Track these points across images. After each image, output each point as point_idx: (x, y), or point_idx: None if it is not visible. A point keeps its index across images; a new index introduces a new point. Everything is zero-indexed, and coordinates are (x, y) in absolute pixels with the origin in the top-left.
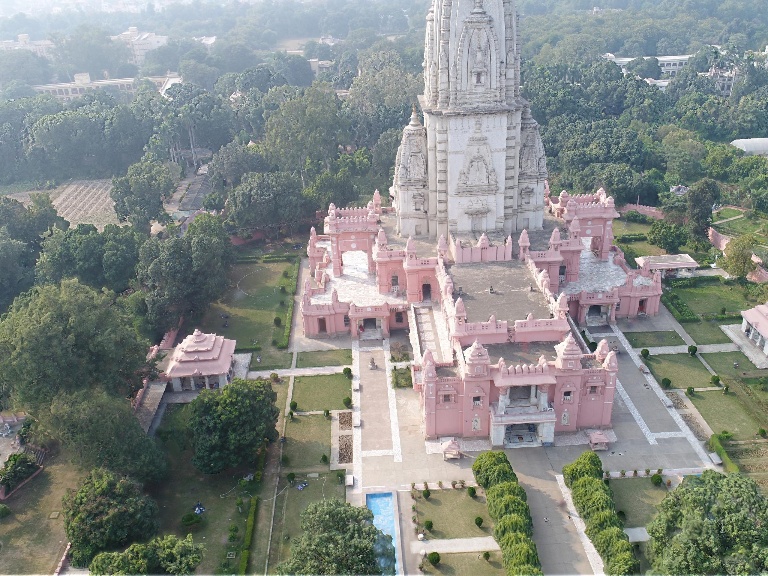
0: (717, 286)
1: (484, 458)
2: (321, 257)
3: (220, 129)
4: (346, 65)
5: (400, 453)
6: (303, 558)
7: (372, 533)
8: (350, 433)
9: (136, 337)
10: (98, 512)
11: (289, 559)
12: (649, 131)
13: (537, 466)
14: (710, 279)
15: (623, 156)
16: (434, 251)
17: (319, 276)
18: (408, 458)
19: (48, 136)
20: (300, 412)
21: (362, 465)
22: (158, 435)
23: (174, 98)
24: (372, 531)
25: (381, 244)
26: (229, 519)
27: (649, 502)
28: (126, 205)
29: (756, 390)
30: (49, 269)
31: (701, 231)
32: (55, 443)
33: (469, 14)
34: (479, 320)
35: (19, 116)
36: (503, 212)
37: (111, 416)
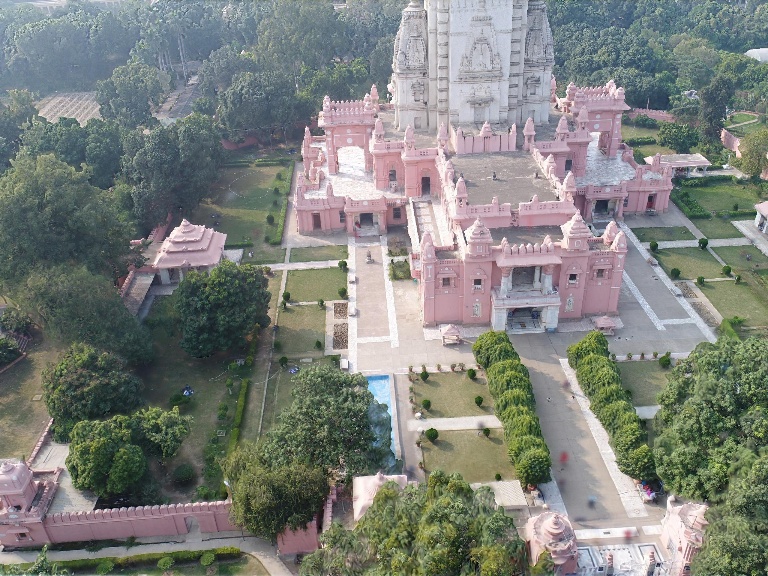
0: (729, 185)
1: (485, 338)
2: (316, 157)
3: (211, 38)
4: None
5: (397, 339)
6: (294, 423)
7: (366, 396)
8: (345, 321)
9: None
10: (79, 384)
11: (279, 426)
12: (660, 41)
13: (540, 350)
14: (722, 179)
15: (633, 62)
16: (434, 143)
17: (313, 174)
18: (405, 344)
19: (30, 45)
20: (293, 303)
21: (357, 351)
22: (145, 324)
23: None
24: (366, 394)
25: (378, 135)
26: (219, 401)
27: (656, 383)
28: (112, 108)
29: None
30: None
31: (713, 132)
32: (38, 332)
33: None
34: (481, 204)
35: (0, 27)
36: (507, 101)
37: (92, 290)
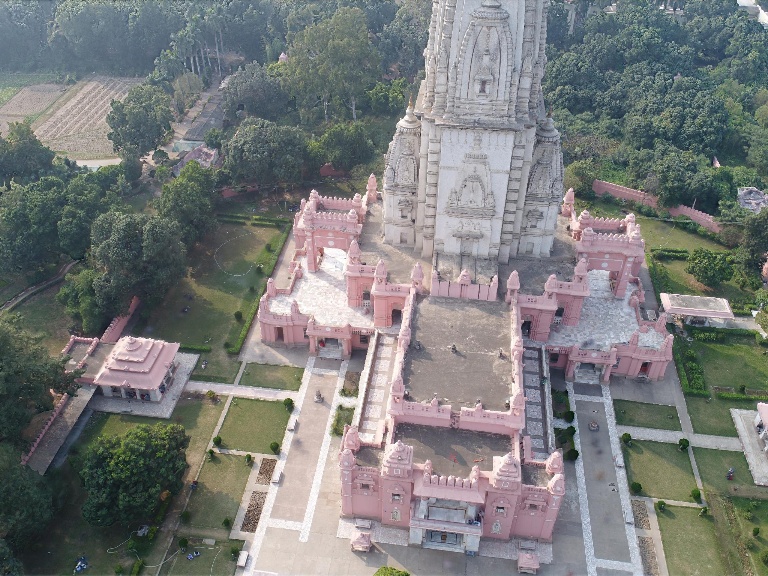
0: (749, 346)
1: None
2: None
3: (252, 34)
4: None
5: (308, 530)
6: None
7: None
8: (265, 490)
9: (82, 319)
10: None
11: None
12: (745, 93)
13: None
14: (744, 334)
15: (697, 134)
16: None
17: (293, 267)
18: (314, 539)
19: (70, 24)
20: (223, 449)
21: (263, 538)
22: (71, 453)
23: None
24: None
25: (352, 257)
26: None
27: None
28: (120, 135)
29: (741, 517)
30: (5, 227)
31: (754, 264)
32: None
33: (479, 6)
34: (424, 394)
35: None
36: (499, 238)
37: None
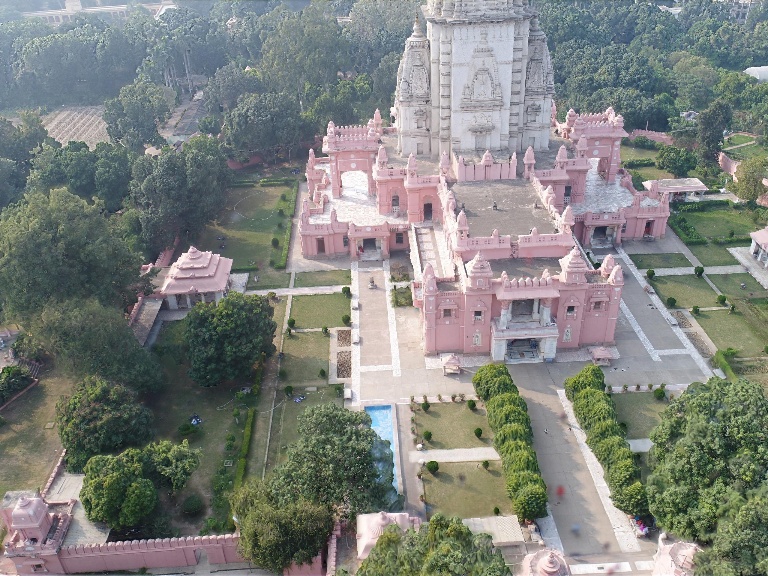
0: (726, 210)
1: (485, 370)
2: (320, 179)
3: (216, 54)
4: None
5: (399, 368)
6: (300, 460)
7: (370, 435)
8: (349, 349)
9: None
10: (92, 417)
11: (286, 462)
12: (660, 58)
13: (538, 381)
14: (719, 203)
15: (632, 82)
16: (436, 170)
17: (318, 197)
18: (407, 373)
19: (38, 59)
20: (298, 329)
21: (361, 379)
22: (154, 350)
23: (168, 24)
24: (370, 433)
25: (381, 162)
26: (226, 430)
27: (651, 415)
28: (119, 127)
29: (763, 310)
30: (40, 187)
31: (711, 156)
32: (50, 358)
33: None
34: (482, 235)
35: (8, 40)
36: (508, 129)
37: (104, 324)
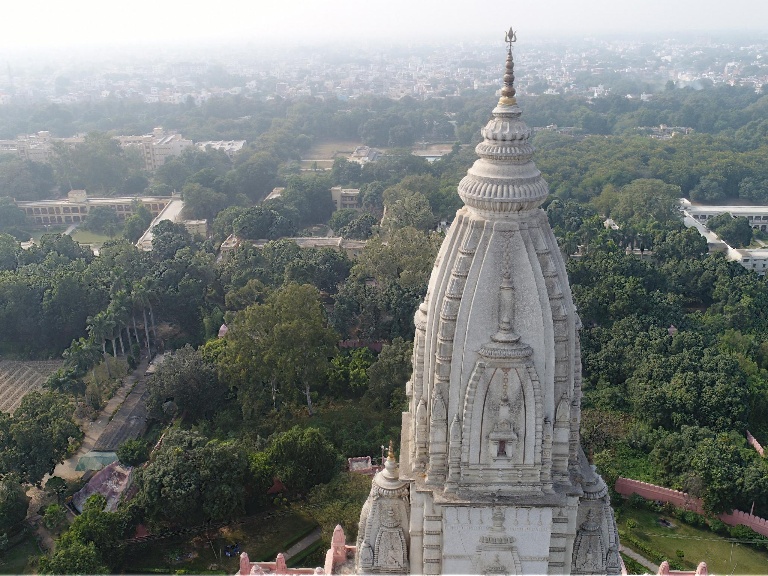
0: None
1: None
2: None
3: (188, 306)
4: (371, 199)
5: None
6: None
7: None
8: None
9: None
10: None
11: None
12: (749, 343)
13: None
14: None
15: (720, 405)
16: None
17: None
18: None
19: None
20: None
21: None
22: None
23: None
24: None
25: None
26: None
27: None
28: (2, 462)
29: None
30: None
31: None
32: None
33: (487, 340)
34: None
35: None
36: None
37: None
